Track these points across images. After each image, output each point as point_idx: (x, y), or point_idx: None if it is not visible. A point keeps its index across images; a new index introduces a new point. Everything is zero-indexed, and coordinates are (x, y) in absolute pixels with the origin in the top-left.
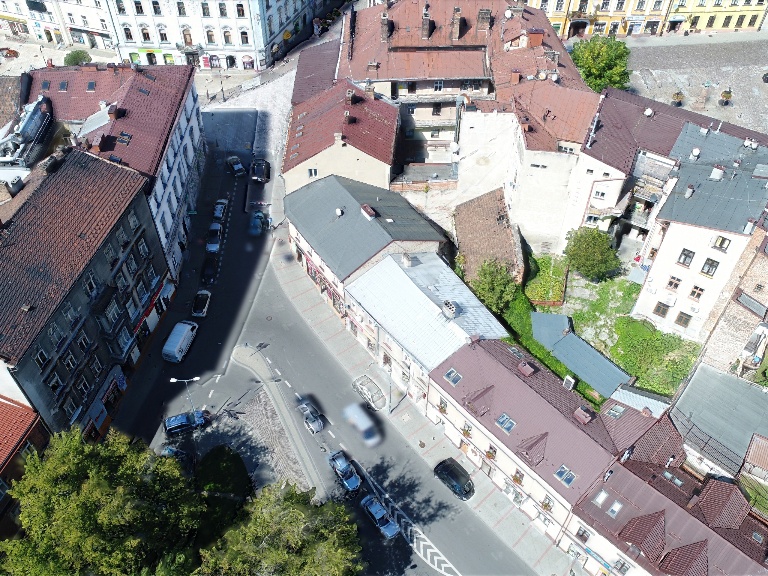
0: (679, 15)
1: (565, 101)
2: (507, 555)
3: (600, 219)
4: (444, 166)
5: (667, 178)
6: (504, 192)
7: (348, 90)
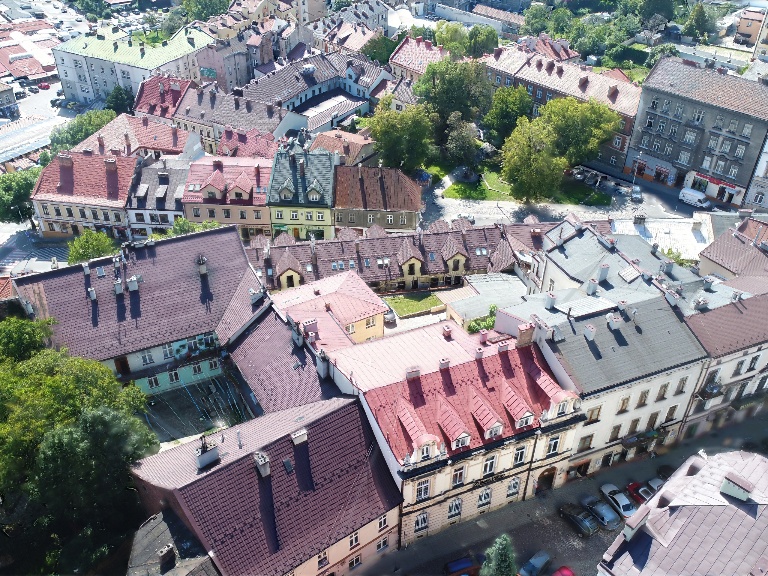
0: None
1: None
2: None
3: None
4: None
5: None
6: None
7: None
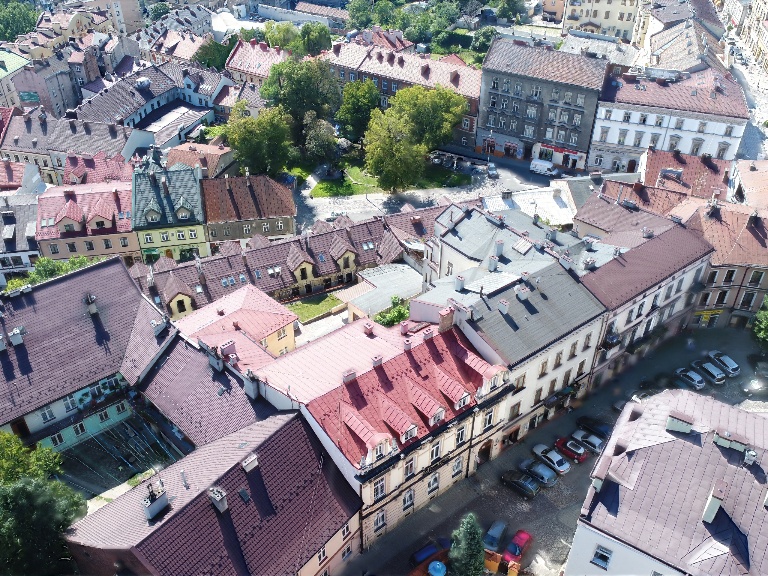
0: None
1: (682, 216)
2: None
3: None
4: None
5: None
6: None
7: None
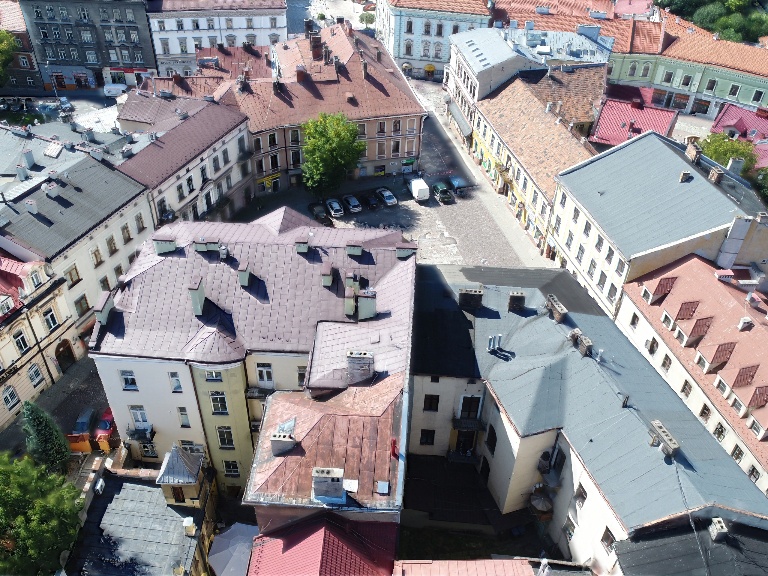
0: (553, 241)
1: None
2: None
3: None
4: None
5: None
6: None
7: None
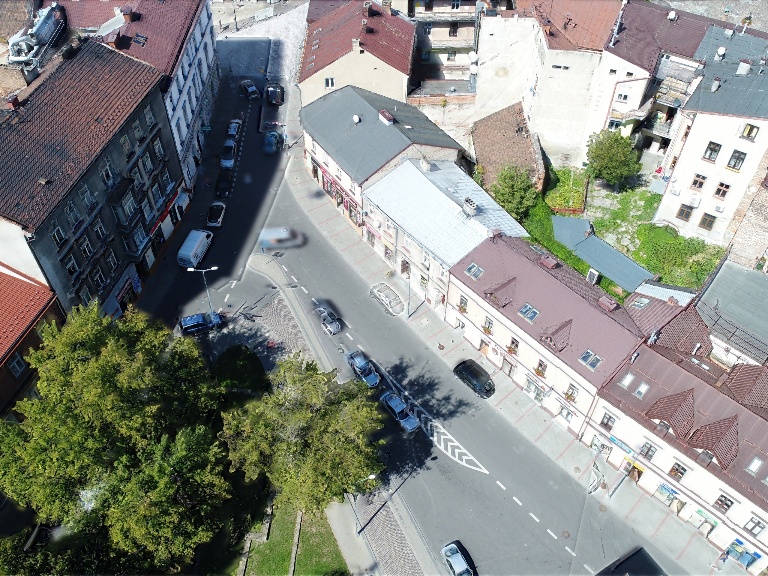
0: None
1: (586, 9)
2: (529, 449)
3: (622, 125)
4: (462, 82)
5: (691, 79)
6: (523, 105)
7: (365, 1)
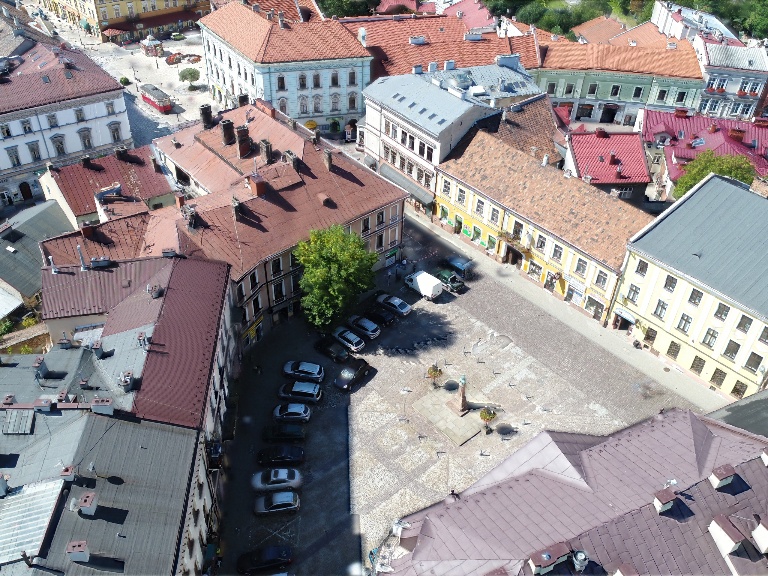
0: (627, 311)
1: (166, 243)
2: None
3: None
4: None
5: None
6: None
7: None
